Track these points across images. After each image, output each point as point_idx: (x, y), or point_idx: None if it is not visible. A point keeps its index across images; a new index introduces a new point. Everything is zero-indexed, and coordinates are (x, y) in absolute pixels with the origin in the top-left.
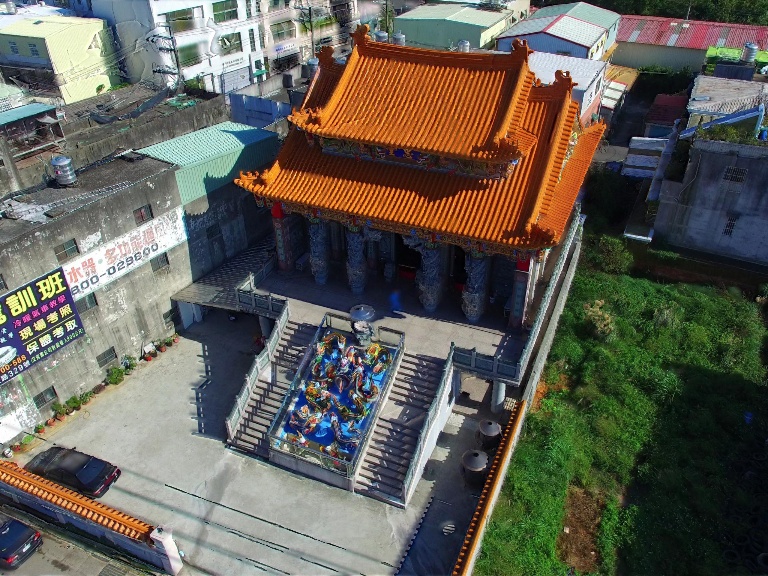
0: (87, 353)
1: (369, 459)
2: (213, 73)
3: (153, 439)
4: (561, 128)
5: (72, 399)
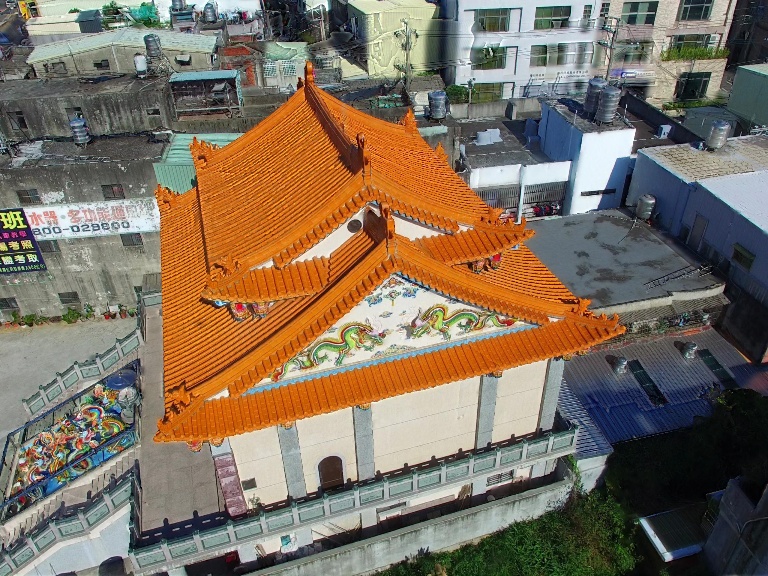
0: (49, 286)
1: (27, 522)
2: (515, 82)
3: (17, 380)
4: (344, 289)
5: (30, 315)
